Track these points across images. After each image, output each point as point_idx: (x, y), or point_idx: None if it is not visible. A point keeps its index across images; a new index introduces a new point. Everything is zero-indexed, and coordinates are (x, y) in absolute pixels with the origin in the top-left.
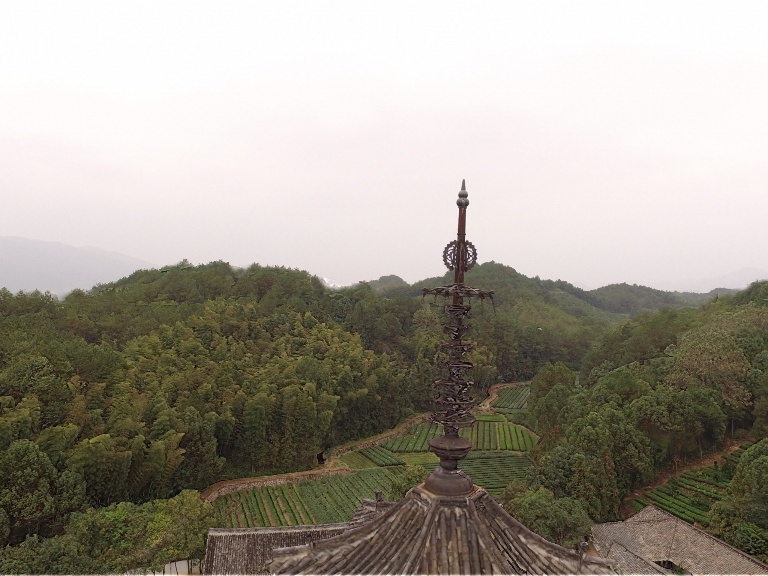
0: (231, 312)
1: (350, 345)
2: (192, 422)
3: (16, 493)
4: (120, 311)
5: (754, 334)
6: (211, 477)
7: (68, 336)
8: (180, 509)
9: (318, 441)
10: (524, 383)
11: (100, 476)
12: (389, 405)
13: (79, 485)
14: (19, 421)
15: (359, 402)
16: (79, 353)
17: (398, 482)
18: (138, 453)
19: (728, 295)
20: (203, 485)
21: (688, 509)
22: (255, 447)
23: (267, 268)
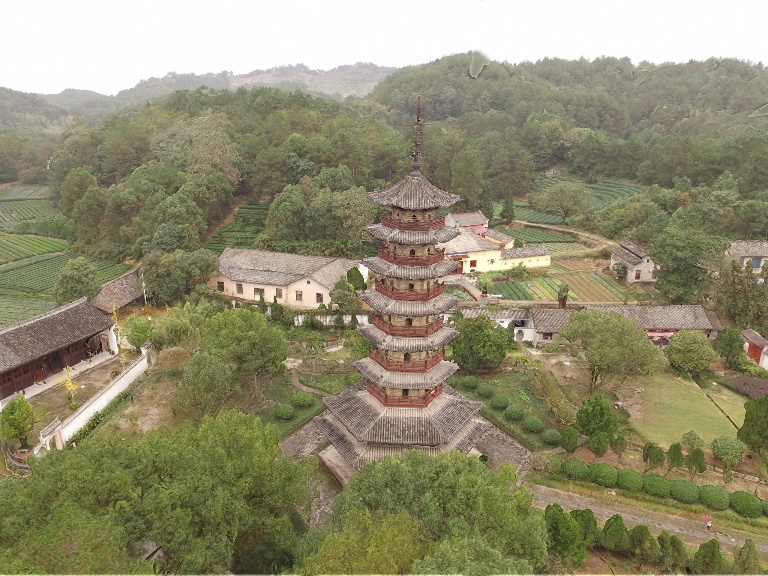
0: None
1: None
2: None
3: None
4: None
5: None
6: None
7: None
8: None
9: None
10: None
11: None
12: None
13: None
14: None
15: None
16: None
17: (69, 273)
18: None
19: (157, 101)
20: None
21: None
22: None
23: None
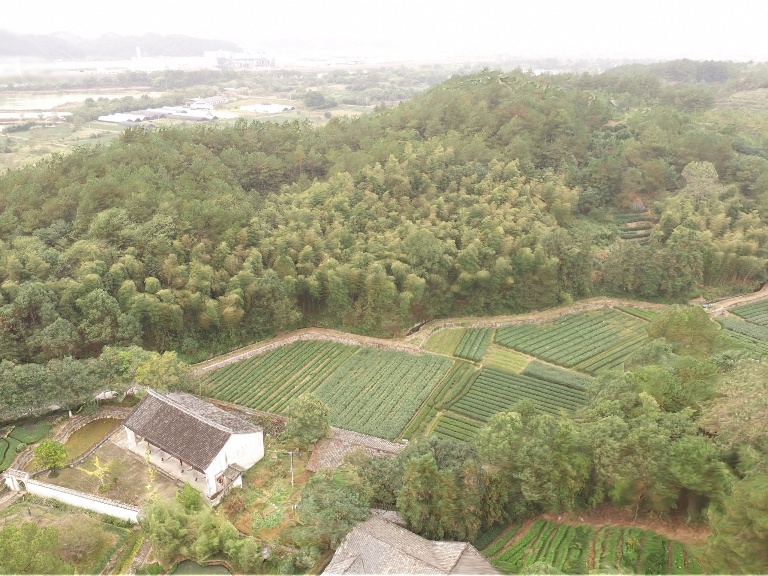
0: None
1: (521, 212)
2: (265, 283)
3: (89, 323)
4: (358, 141)
5: None
6: (310, 321)
7: (214, 194)
8: None
9: (396, 316)
10: None
11: (158, 318)
12: (534, 288)
13: (132, 324)
14: (114, 272)
15: (481, 282)
16: (205, 213)
17: None
18: (198, 305)
19: None
20: (297, 326)
21: None
22: (341, 307)
23: (537, 89)
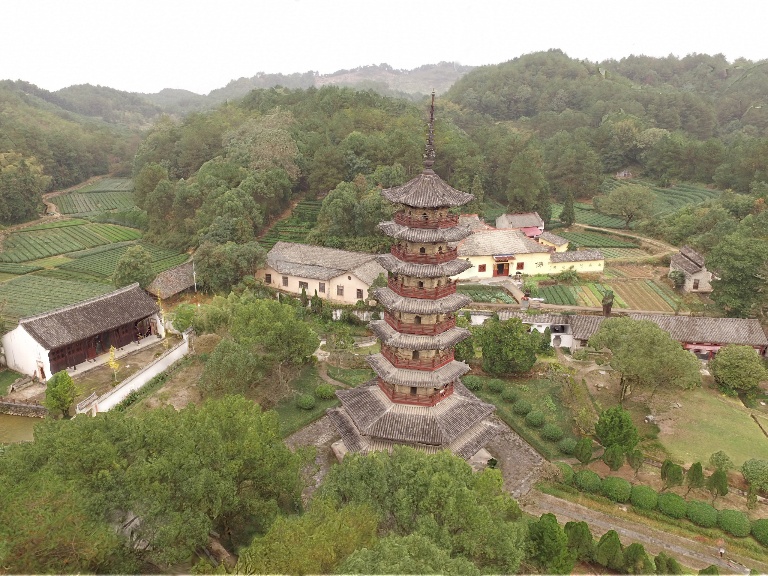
0: None
1: None
2: None
3: None
4: None
5: (288, 130)
6: None
7: None
8: None
9: None
10: (66, 191)
11: None
12: None
13: None
14: None
15: None
16: None
17: (127, 260)
18: None
19: (234, 100)
20: None
21: None
22: None
23: None
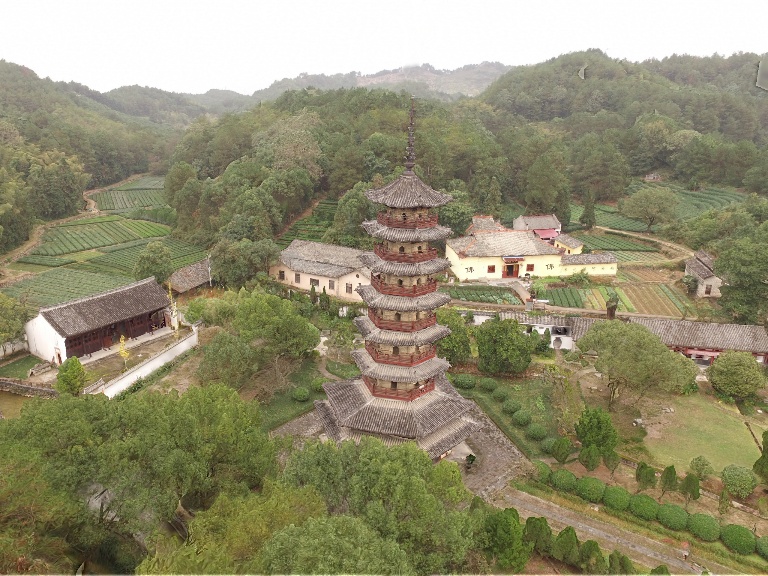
0: None
1: None
2: None
3: None
4: None
5: (313, 131)
6: None
7: None
8: None
9: None
10: (107, 188)
11: None
12: (23, 218)
13: None
14: None
15: (3, 217)
16: None
17: (146, 255)
18: None
19: (268, 101)
20: None
21: None
22: None
23: None
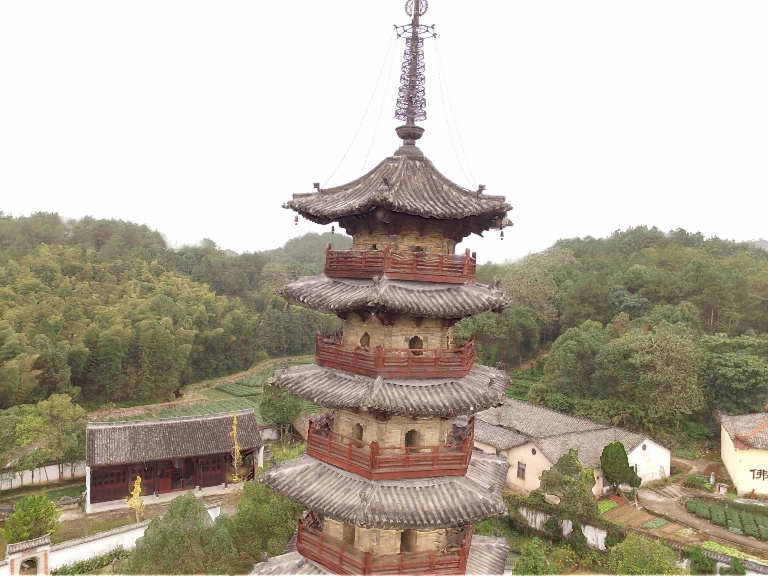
0: (71, 254)
1: (202, 290)
2: (44, 348)
3: None
4: None
5: (560, 269)
6: None
7: None
8: (51, 411)
9: (176, 373)
10: None
11: None
12: (243, 347)
13: None
14: None
15: (214, 341)
16: None
17: None
18: None
19: None
20: None
21: (512, 397)
22: (110, 380)
23: (103, 220)
